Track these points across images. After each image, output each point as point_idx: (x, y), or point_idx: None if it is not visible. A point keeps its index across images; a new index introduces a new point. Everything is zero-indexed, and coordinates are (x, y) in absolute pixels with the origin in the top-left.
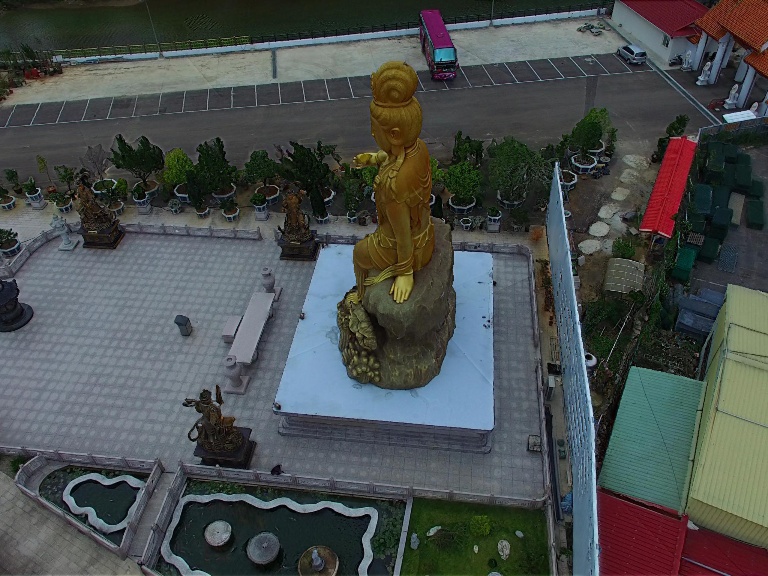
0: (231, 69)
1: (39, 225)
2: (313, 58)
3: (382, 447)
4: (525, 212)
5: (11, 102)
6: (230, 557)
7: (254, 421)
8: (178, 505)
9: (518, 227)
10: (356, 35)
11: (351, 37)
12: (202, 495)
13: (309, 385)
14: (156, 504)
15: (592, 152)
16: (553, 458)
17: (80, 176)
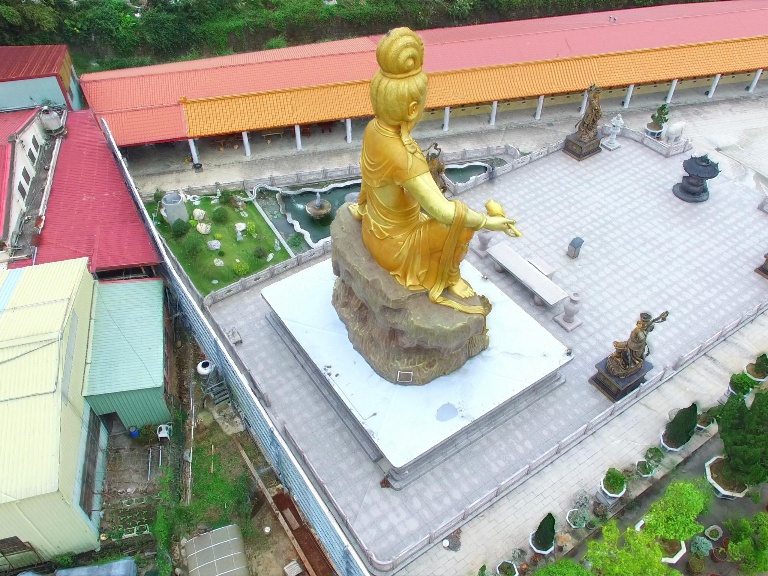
0: None
1: None
2: None
3: None
4: None
5: None
6: None
7: None
8: None
9: None
10: None
11: None
12: None
13: None
14: None
15: None
16: None
17: None
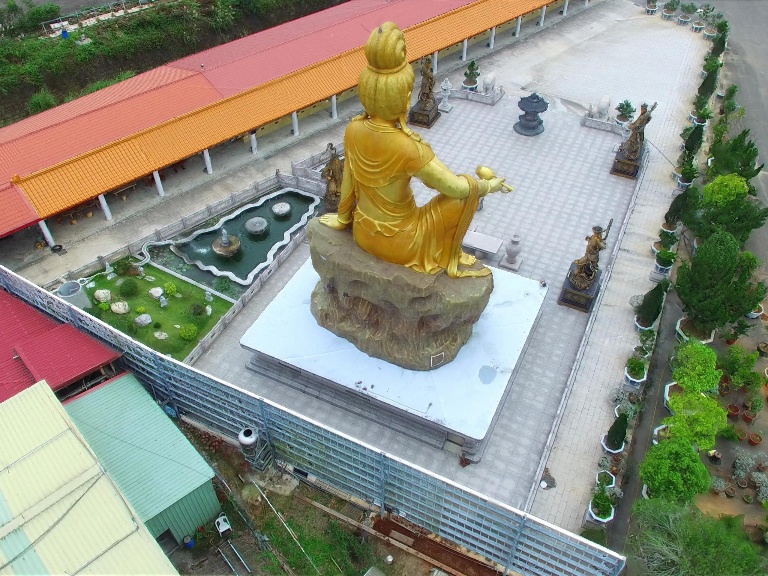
0: None
1: (662, 136)
2: None
3: None
4: None
5: None
6: (266, 215)
7: None
8: (315, 195)
9: None
10: None
11: None
12: None
13: None
14: None
15: None
16: None
17: None
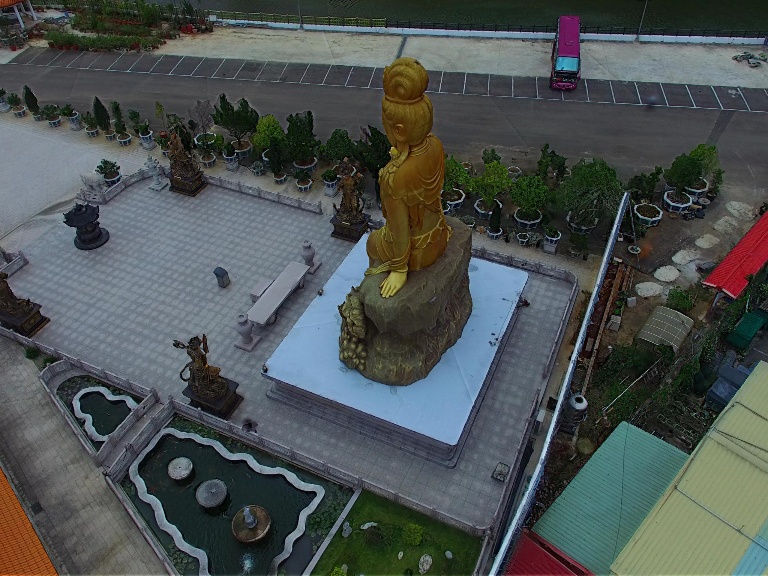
0: (359, 49)
1: (143, 163)
2: (440, 49)
3: (353, 433)
4: (584, 239)
5: (161, 51)
6: (183, 492)
7: (250, 378)
8: (158, 434)
9: (575, 253)
10: (490, 32)
11: (485, 33)
12: (181, 431)
13: (301, 357)
14: (141, 427)
15: (691, 191)
16: (516, 492)
17: (175, 125)
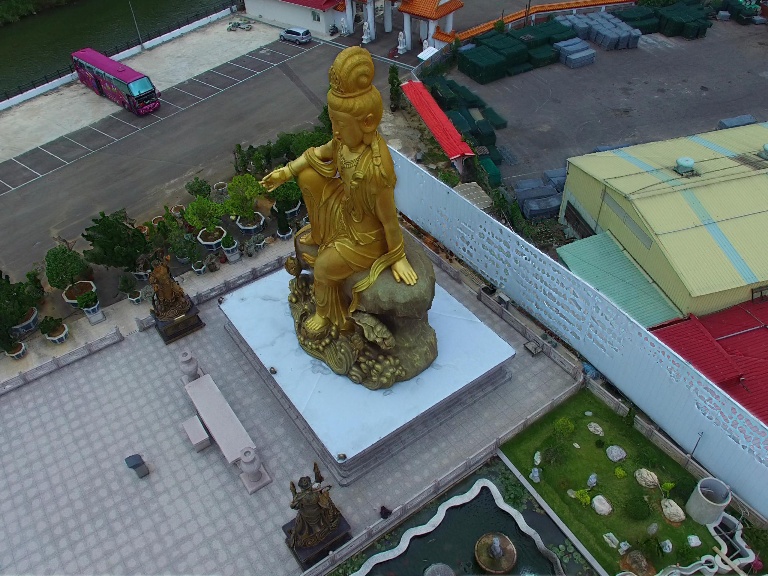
0: None
1: None
2: None
3: (437, 431)
4: None
5: None
6: None
7: None
8: None
9: None
10: (3, 103)
11: None
12: None
13: (347, 421)
14: None
15: None
16: None
17: None
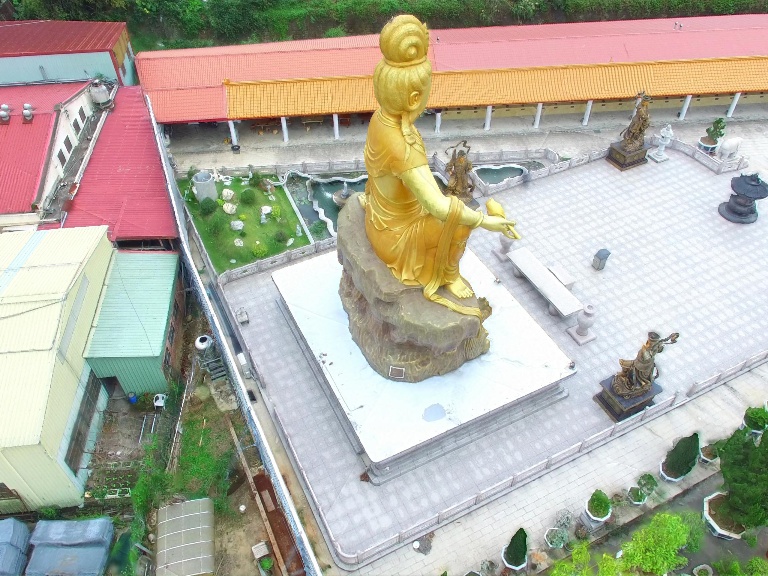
0: None
1: None
2: None
3: None
4: None
5: None
6: None
7: None
8: None
9: None
10: None
11: None
12: None
13: None
14: None
15: None
16: (225, 320)
17: None
